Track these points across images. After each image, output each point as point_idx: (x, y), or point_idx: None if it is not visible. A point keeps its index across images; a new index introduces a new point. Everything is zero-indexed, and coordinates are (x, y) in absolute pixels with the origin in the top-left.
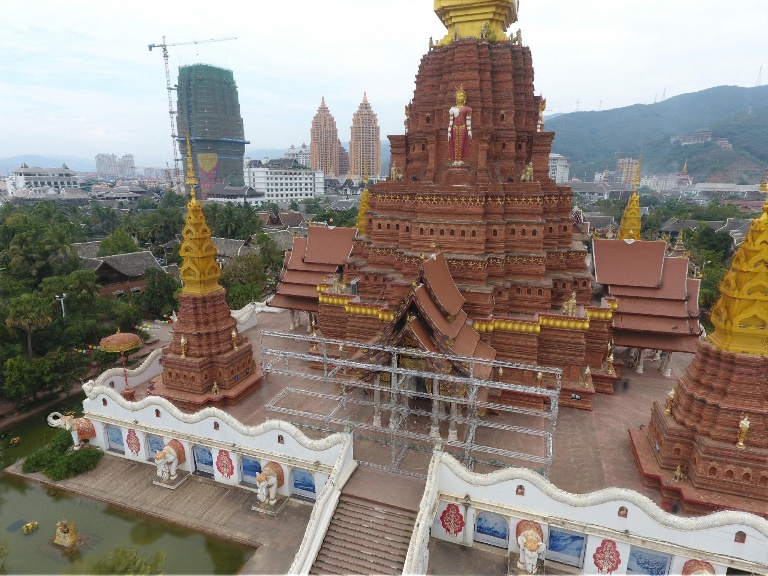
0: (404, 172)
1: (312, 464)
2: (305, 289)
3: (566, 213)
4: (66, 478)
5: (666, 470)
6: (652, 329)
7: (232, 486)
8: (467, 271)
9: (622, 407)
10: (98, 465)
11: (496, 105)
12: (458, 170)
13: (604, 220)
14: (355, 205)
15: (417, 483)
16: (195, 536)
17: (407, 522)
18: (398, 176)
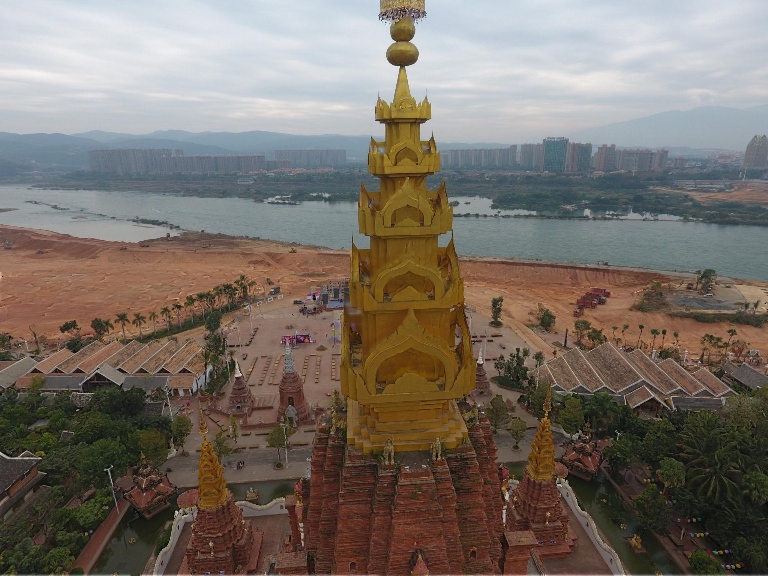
0: None
1: None
2: None
3: None
4: None
5: None
6: None
7: None
8: None
9: None
10: None
11: None
12: None
13: None
14: None
15: None
16: None
17: None
18: None
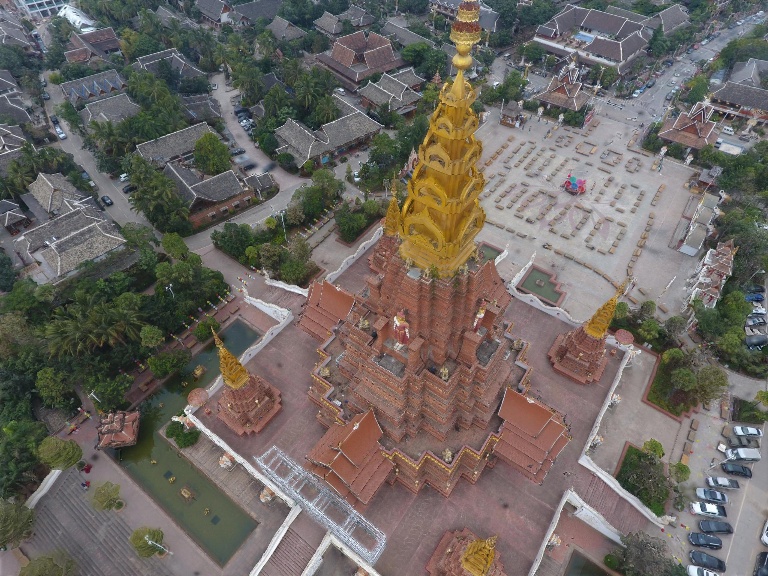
0: None
1: (284, 499)
2: (318, 327)
3: (481, 381)
4: (185, 447)
5: (437, 570)
6: (515, 461)
7: (255, 478)
8: (388, 417)
9: (469, 499)
10: (198, 440)
11: (433, 317)
12: (397, 352)
13: (760, 96)
14: None
15: (324, 531)
16: (236, 507)
17: (311, 553)
18: (365, 323)
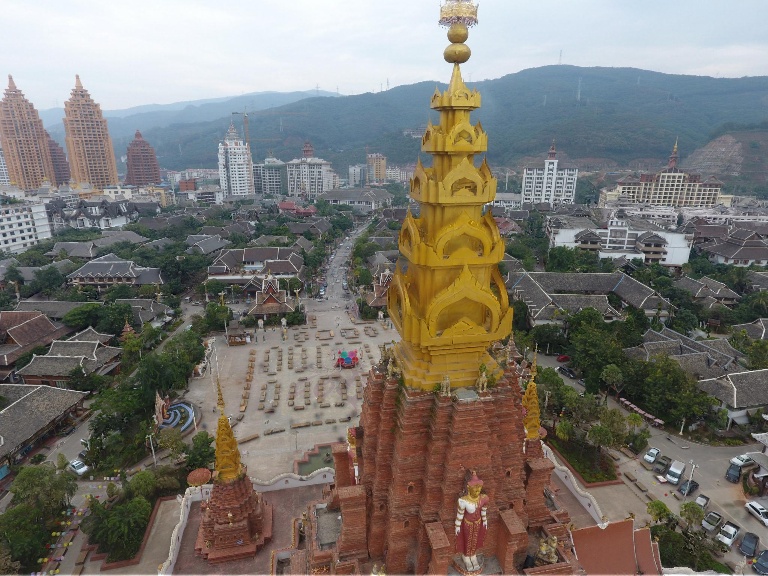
0: (364, 532)
1: None
2: None
3: None
4: None
5: None
6: None
7: None
8: None
9: None
10: None
11: None
12: (477, 575)
13: None
14: (115, 268)
15: None
16: None
17: None
18: None
